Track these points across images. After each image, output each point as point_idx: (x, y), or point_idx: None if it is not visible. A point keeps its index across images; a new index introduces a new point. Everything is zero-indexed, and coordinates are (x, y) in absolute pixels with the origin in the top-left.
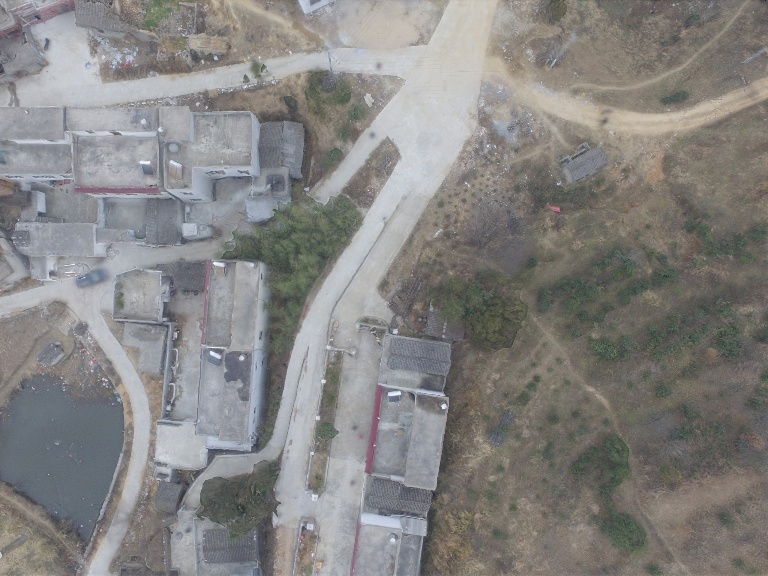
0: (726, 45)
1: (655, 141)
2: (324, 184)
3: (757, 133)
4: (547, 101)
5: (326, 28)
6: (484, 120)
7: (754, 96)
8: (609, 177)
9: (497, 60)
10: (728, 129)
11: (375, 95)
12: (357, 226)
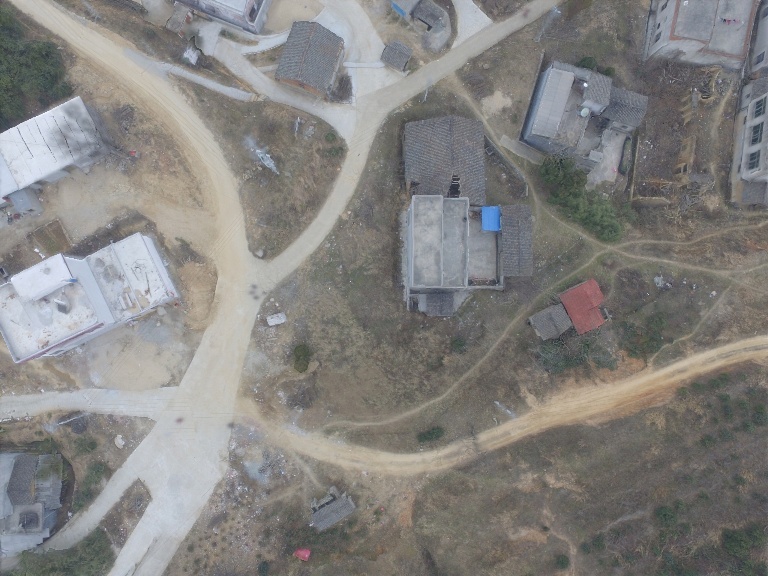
0: (486, 374)
1: (407, 482)
2: (82, 516)
3: (502, 484)
4: (299, 442)
5: (77, 369)
6: (234, 464)
7: (506, 436)
8: (362, 518)
9: (248, 401)
10: (475, 476)
11: (126, 436)
12: (108, 569)
